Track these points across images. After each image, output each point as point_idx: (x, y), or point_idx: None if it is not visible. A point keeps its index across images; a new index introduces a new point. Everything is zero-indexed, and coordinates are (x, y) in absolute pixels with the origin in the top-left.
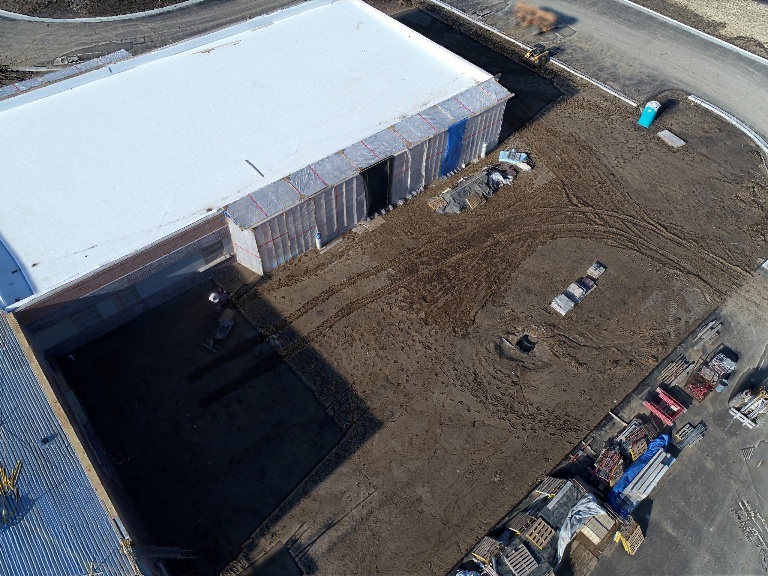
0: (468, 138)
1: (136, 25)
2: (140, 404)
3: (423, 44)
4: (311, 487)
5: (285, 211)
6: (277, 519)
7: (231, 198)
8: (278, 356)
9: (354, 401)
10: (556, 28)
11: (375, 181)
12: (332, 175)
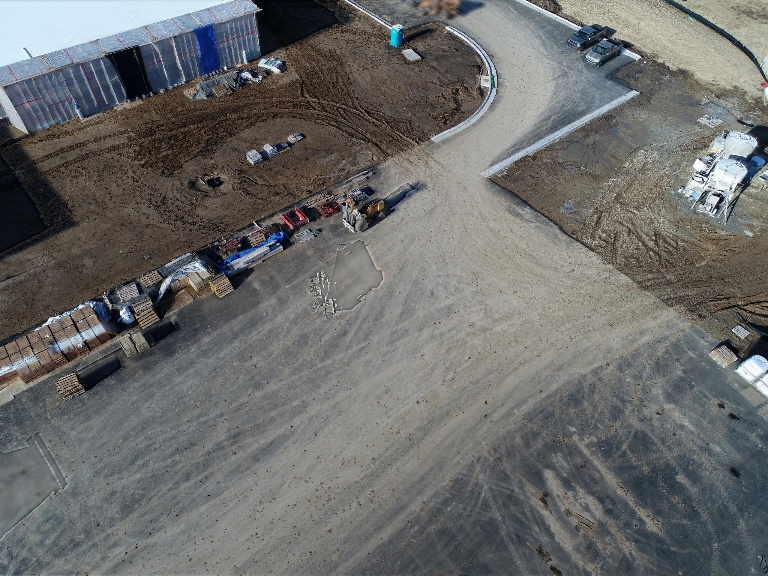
0: (222, 43)
1: None
2: None
3: None
4: (6, 256)
5: (33, 77)
6: None
7: None
8: (18, 183)
9: (63, 210)
10: None
11: (127, 67)
12: (80, 56)
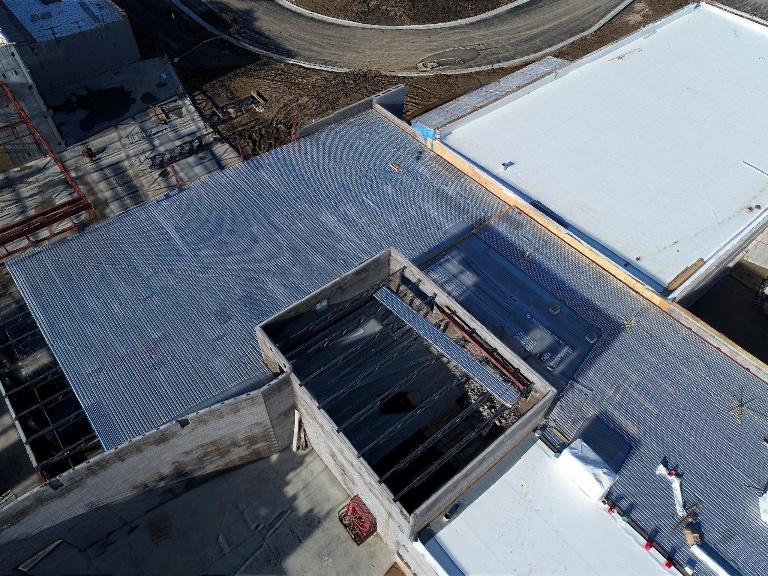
0: None
1: (466, 32)
2: None
3: None
4: None
5: None
6: None
7: (760, 197)
8: None
9: None
10: None
11: None
12: None
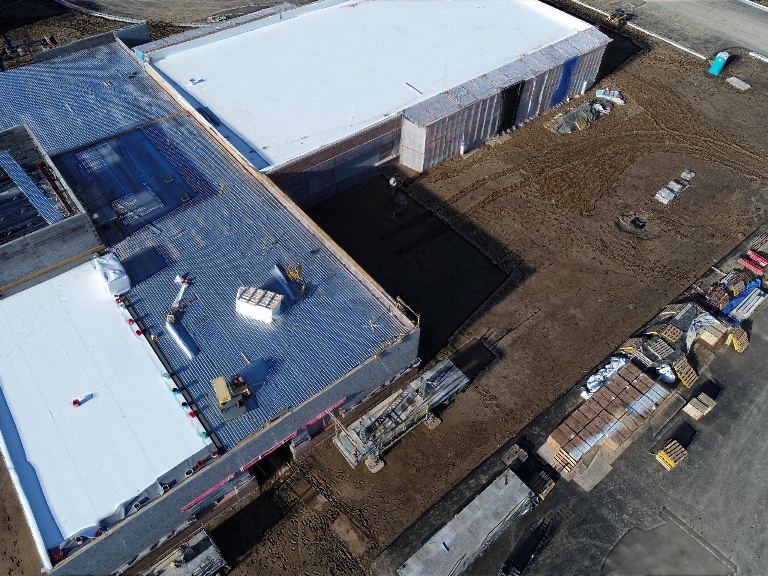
0: (575, 74)
1: None
2: None
3: (528, 3)
4: (491, 307)
5: (449, 115)
6: (470, 325)
7: (401, 108)
8: (446, 225)
9: (511, 255)
10: None
11: (507, 102)
12: (480, 92)
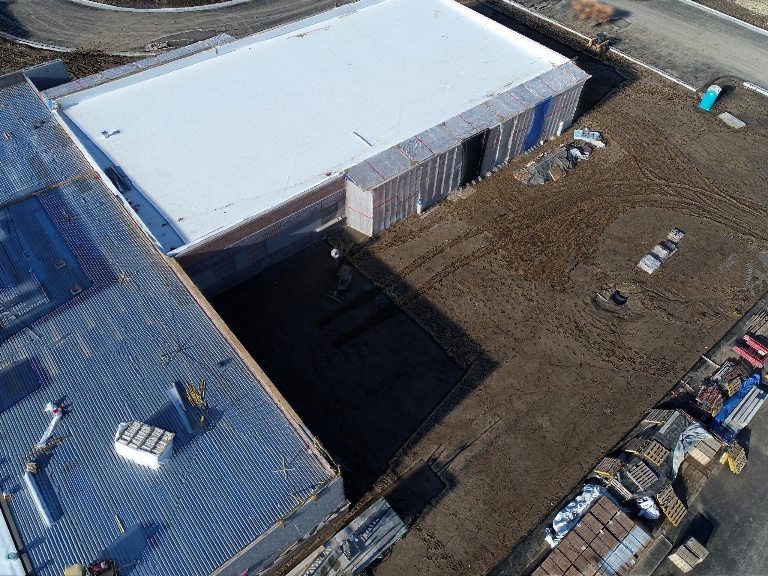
0: (549, 116)
1: (216, 15)
2: (278, 344)
3: (499, 31)
4: (442, 415)
5: (399, 175)
6: (416, 441)
7: (346, 164)
8: (396, 306)
9: (470, 344)
10: (611, 20)
11: (470, 152)
12: (437, 144)
